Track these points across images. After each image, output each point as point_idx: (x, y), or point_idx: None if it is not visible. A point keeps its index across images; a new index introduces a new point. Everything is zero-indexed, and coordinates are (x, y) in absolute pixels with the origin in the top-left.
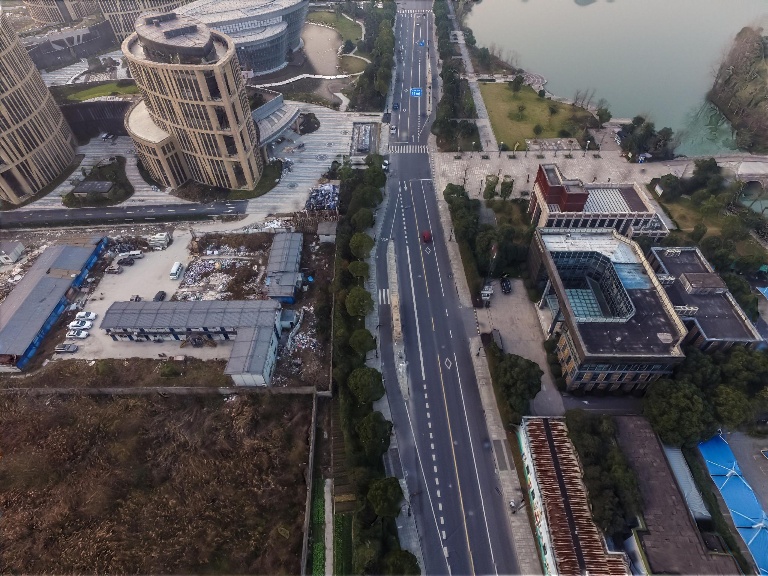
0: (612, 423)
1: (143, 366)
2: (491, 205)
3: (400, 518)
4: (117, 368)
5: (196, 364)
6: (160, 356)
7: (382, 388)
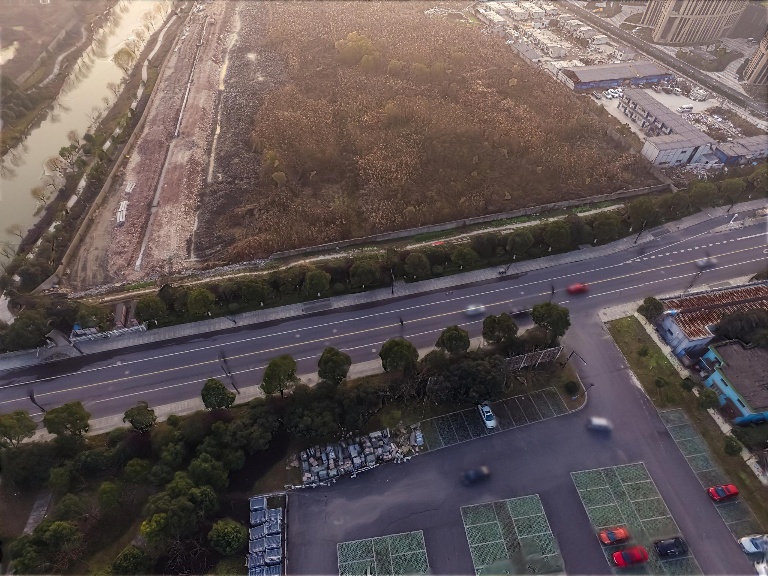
0: None
1: (615, 121)
2: None
3: (630, 239)
4: (605, 113)
5: (636, 138)
6: (626, 124)
7: (708, 200)
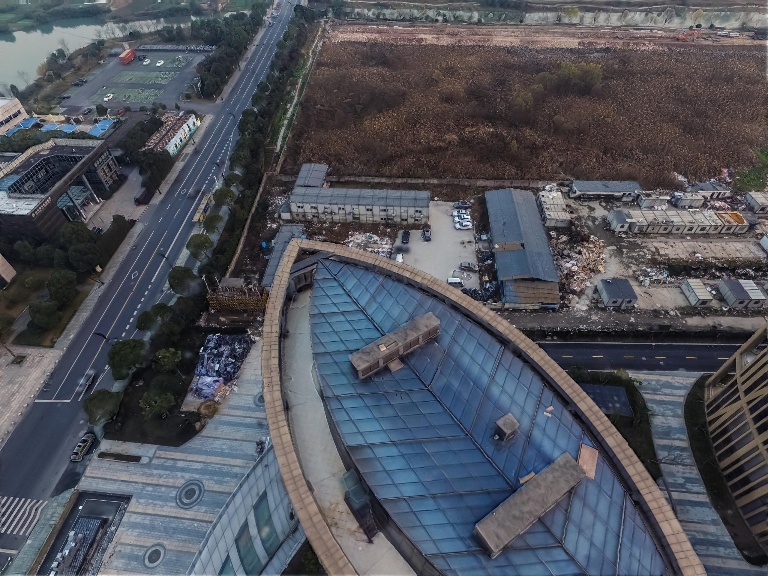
0: (120, 139)
1: None
2: (6, 332)
3: None
4: None
5: None
6: None
7: None
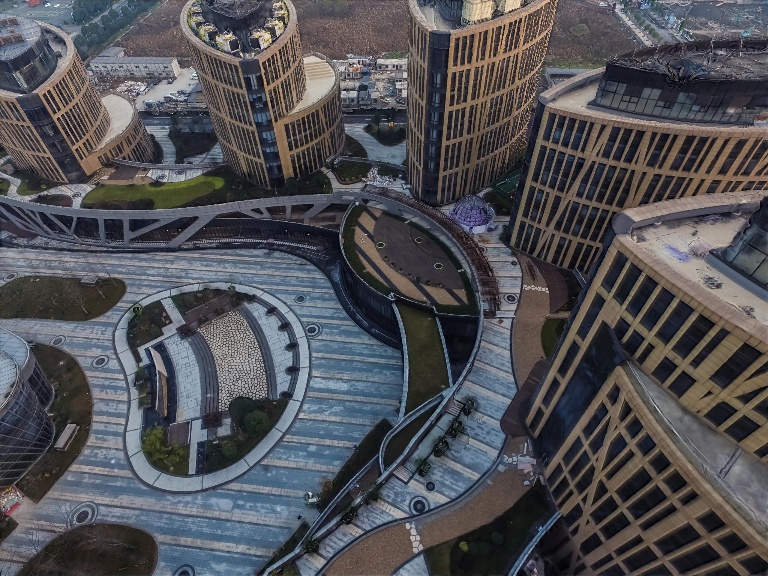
0: None
1: None
2: None
3: None
4: None
5: None
6: None
7: None
